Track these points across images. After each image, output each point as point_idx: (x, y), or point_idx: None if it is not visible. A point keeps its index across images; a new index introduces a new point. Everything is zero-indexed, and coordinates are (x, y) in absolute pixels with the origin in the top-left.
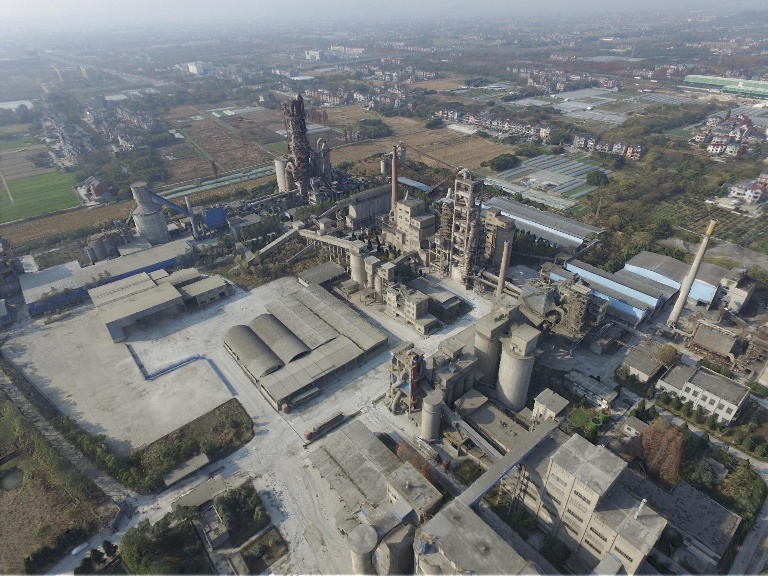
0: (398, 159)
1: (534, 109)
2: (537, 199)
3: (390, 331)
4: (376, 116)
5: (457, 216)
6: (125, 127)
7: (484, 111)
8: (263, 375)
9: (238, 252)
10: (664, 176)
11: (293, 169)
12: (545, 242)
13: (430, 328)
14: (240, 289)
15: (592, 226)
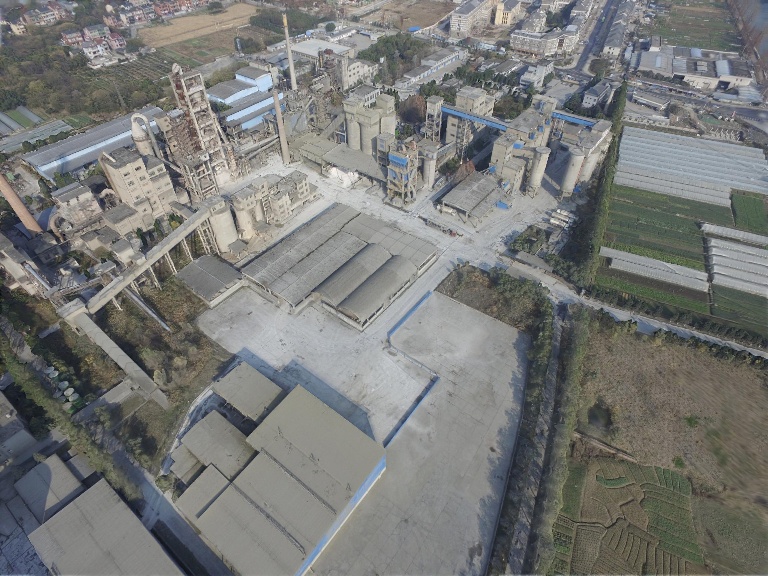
0: None
1: None
2: (33, 140)
3: (315, 216)
4: None
5: None
6: None
7: None
8: None
9: None
10: (32, 69)
11: None
12: None
13: None
14: (230, 368)
15: (139, 110)
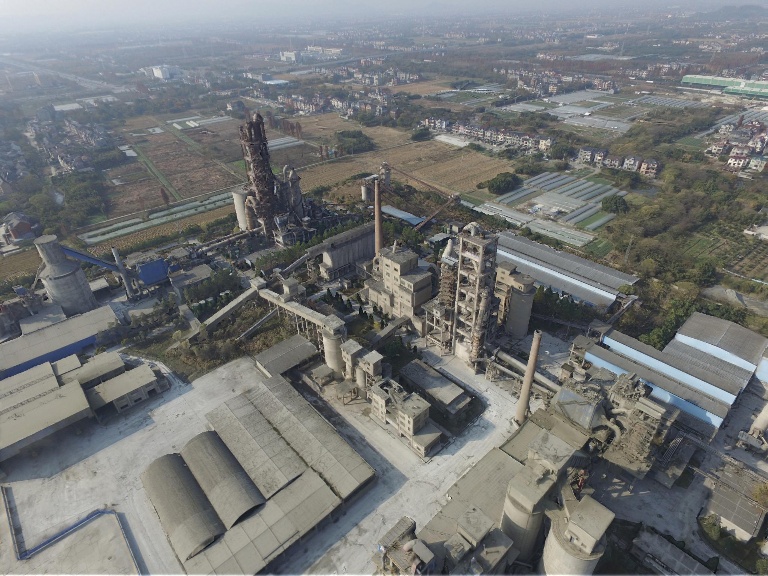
0: (382, 183)
1: (528, 116)
2: (548, 232)
3: (378, 451)
4: (356, 126)
5: (462, 281)
6: (70, 144)
7: (474, 118)
8: (191, 555)
9: (180, 321)
10: (691, 200)
11: (254, 204)
12: (567, 296)
13: (433, 446)
14: (178, 380)
15: (622, 272)
